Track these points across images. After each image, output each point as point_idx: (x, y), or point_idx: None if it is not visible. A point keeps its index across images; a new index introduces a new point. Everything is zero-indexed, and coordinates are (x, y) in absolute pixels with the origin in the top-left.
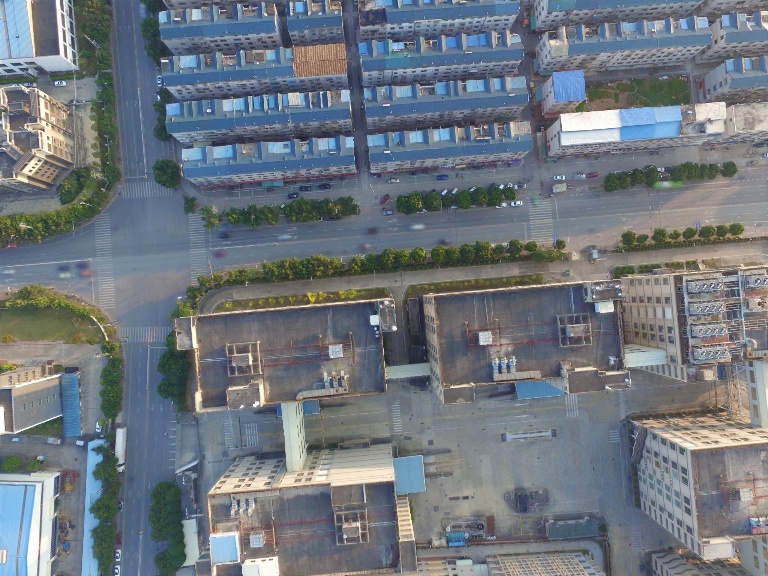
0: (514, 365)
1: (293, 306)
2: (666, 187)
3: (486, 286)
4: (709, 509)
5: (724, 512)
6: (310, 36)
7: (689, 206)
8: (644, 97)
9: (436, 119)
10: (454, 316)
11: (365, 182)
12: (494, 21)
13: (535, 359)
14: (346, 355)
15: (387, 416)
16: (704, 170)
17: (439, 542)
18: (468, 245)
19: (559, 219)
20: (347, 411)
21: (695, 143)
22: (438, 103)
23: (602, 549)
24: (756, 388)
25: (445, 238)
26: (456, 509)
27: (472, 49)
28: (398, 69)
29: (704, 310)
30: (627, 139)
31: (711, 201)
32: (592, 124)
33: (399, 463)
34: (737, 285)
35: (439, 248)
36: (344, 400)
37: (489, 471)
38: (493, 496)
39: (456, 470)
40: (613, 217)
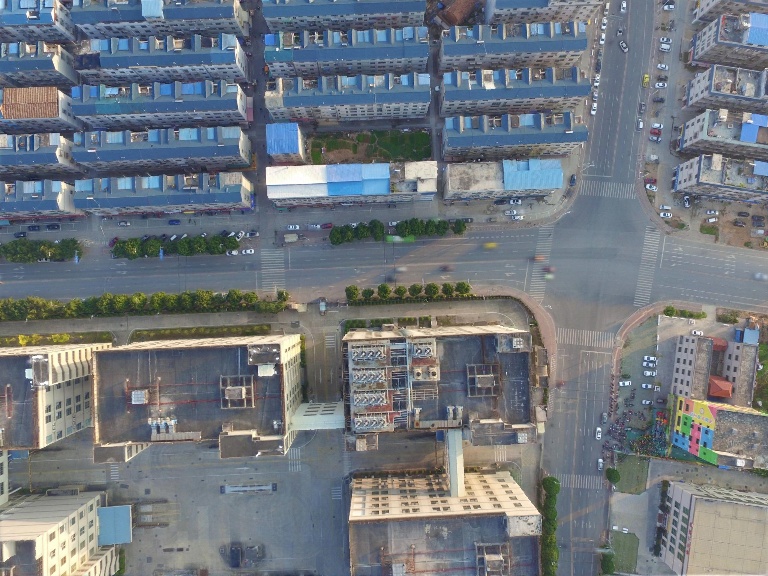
0: (173, 425)
1: (6, 348)
2: (399, 241)
3: (212, 334)
4: None
5: None
6: (31, 77)
7: (425, 261)
8: (384, 149)
9: (160, 165)
10: (116, 372)
11: (96, 224)
12: (218, 69)
13: (198, 420)
14: (0, 408)
15: None
16: (428, 227)
17: None
18: (186, 293)
19: (291, 269)
20: (64, 456)
21: (424, 199)
22: (146, 151)
23: None
24: (449, 455)
25: (174, 284)
26: (170, 561)
27: (185, 97)
28: (111, 114)
29: (361, 378)
30: (335, 195)
31: (448, 257)
32: (297, 179)
33: (105, 513)
34: (405, 353)
35: (155, 295)
36: (62, 444)
37: (206, 523)
38: (208, 549)
39: (172, 521)
40: (346, 269)
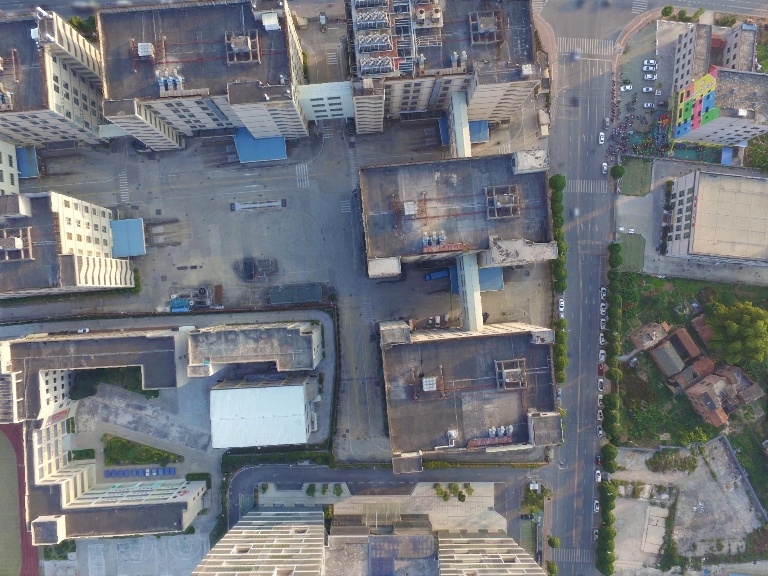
0: (181, 82)
1: None
2: None
3: None
4: (381, 229)
5: (396, 232)
6: None
7: None
8: None
9: None
10: (121, 34)
11: None
12: None
13: (205, 78)
14: (8, 70)
15: (114, 185)
16: None
17: (163, 308)
18: None
19: None
20: (73, 180)
21: None
22: None
23: (332, 319)
24: (455, 129)
25: None
26: (184, 279)
27: None
28: None
29: (365, 18)
30: None
31: None
32: None
33: (117, 225)
34: (407, 0)
35: None
36: (70, 169)
37: (218, 241)
38: (222, 266)
39: (184, 240)
40: None
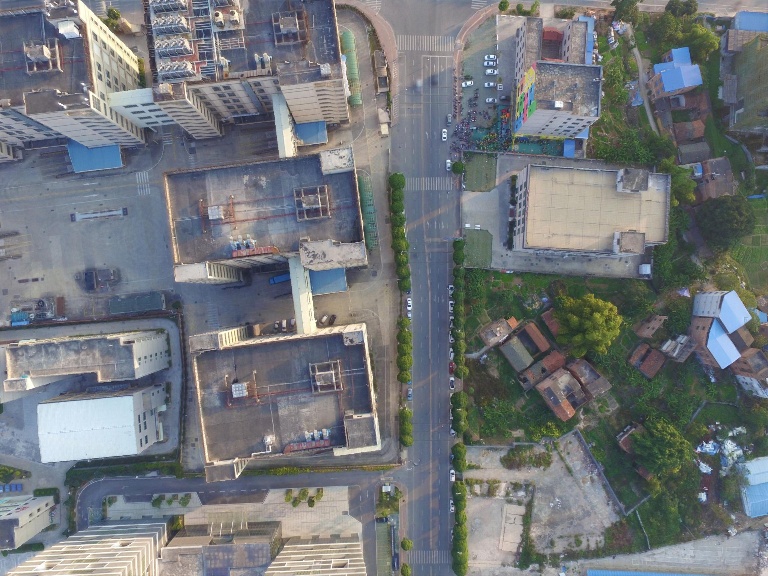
0: None
1: None
2: None
3: None
4: (190, 235)
5: (206, 238)
6: None
7: None
8: None
9: None
10: None
11: None
12: None
13: (6, 89)
14: None
15: None
16: None
17: (3, 323)
18: None
19: None
20: None
21: None
22: None
23: (178, 327)
24: (276, 131)
25: None
26: (25, 292)
27: None
28: None
29: (159, 23)
30: None
31: None
32: None
33: None
34: (207, 4)
35: None
36: None
37: (59, 252)
38: (64, 277)
39: (25, 252)
40: None
